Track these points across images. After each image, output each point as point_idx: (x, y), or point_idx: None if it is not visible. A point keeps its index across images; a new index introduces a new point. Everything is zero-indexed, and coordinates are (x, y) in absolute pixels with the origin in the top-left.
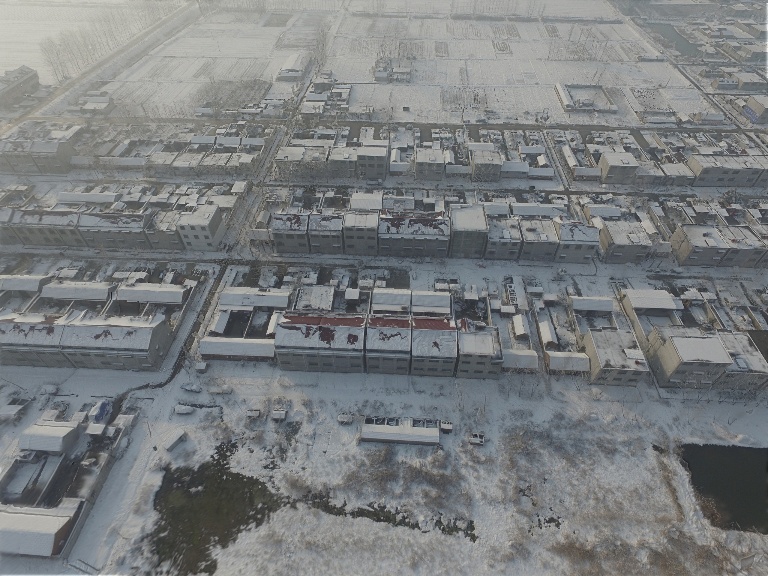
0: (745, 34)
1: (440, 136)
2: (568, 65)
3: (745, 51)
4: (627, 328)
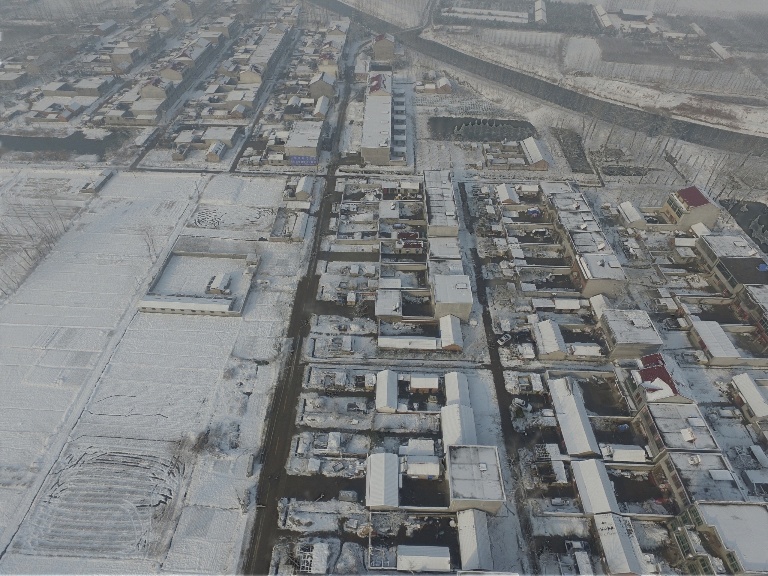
0: (82, 98)
1: (323, 575)
2: (54, 272)
3: (142, 113)
4: (750, 372)
